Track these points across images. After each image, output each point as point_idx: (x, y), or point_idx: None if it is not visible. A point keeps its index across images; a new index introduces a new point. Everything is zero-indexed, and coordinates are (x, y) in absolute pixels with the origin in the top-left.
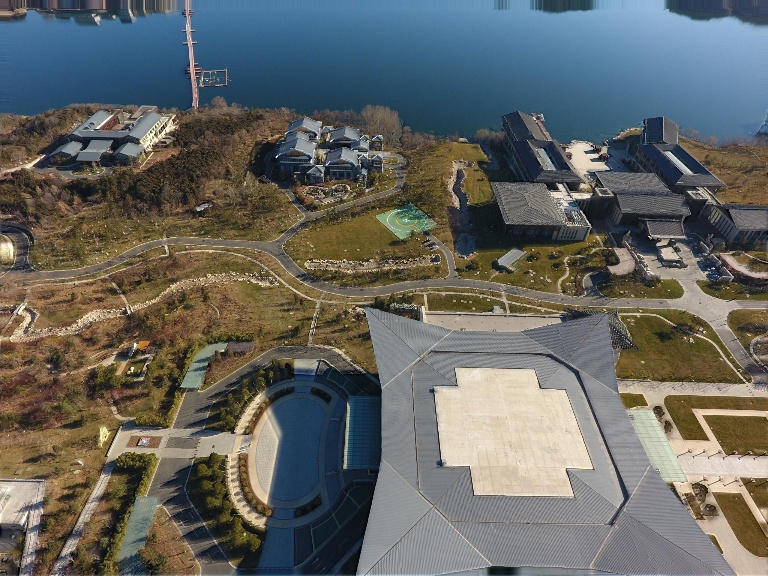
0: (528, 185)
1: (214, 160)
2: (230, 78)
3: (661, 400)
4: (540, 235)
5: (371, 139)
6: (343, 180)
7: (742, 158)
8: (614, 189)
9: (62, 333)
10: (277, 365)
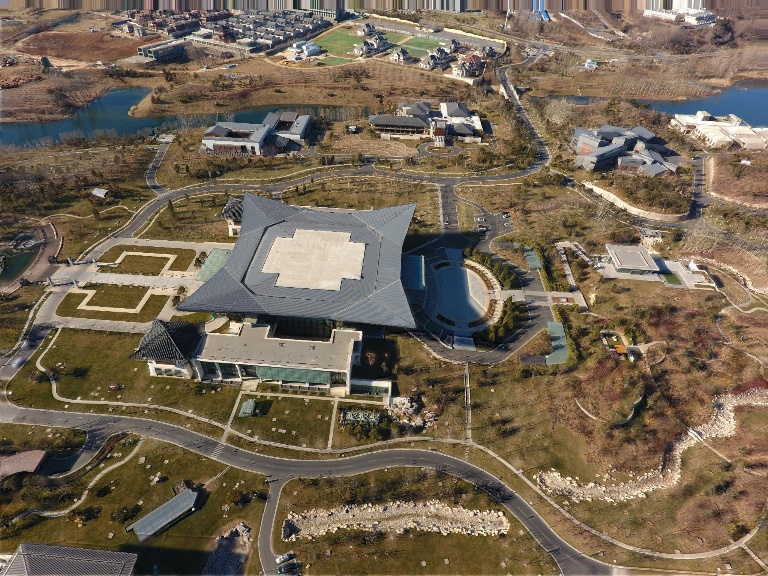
0: None
1: None
2: None
3: None
4: None
5: None
6: None
7: None
8: None
9: (733, 401)
10: None
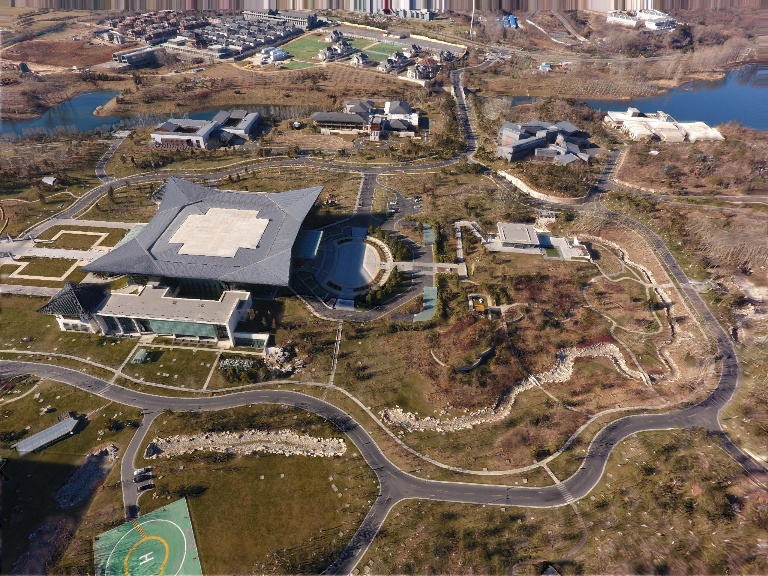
0: None
1: None
2: None
3: None
4: None
5: None
6: None
7: None
8: None
9: (577, 354)
10: None
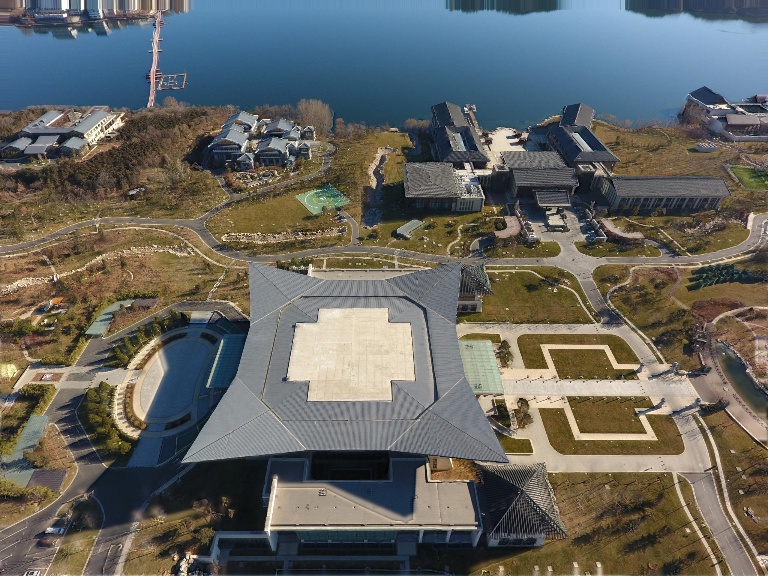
0: (435, 164)
1: (152, 151)
2: (188, 81)
3: (515, 338)
4: (441, 207)
5: (303, 130)
6: (272, 166)
7: (653, 139)
8: (514, 166)
9: None
10: (174, 315)
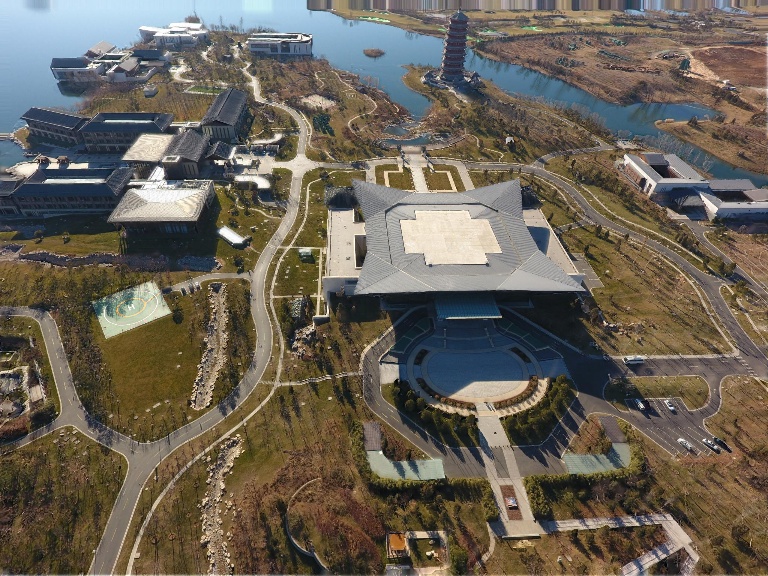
0: (129, 198)
1: None
2: None
3: None
4: (202, 214)
5: None
6: None
7: (113, 105)
8: (159, 157)
9: None
10: None
